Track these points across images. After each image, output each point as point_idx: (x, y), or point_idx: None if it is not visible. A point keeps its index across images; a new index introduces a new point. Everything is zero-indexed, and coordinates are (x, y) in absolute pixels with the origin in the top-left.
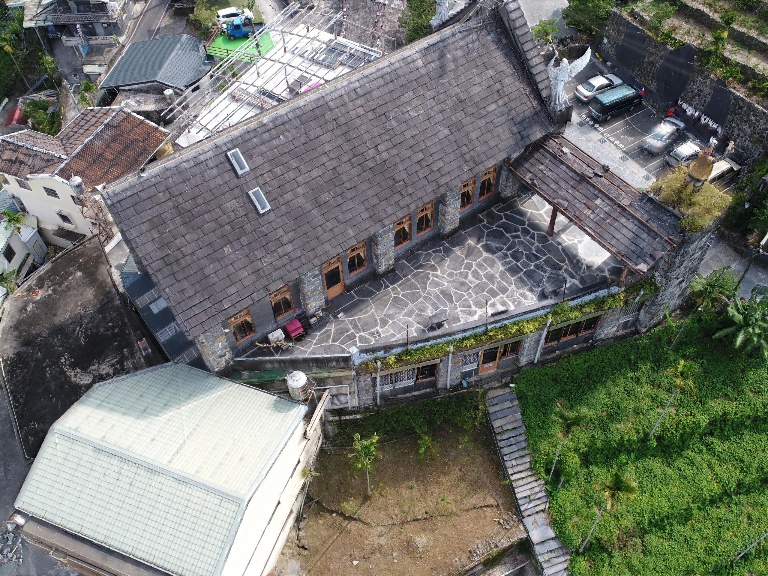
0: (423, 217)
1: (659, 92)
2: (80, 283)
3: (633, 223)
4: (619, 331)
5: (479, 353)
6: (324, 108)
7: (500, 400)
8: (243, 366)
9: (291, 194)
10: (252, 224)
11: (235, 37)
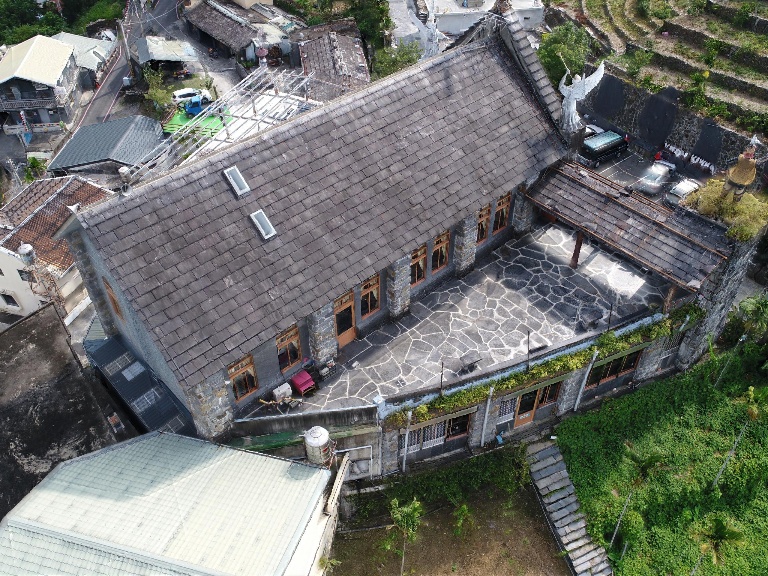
0: (438, 251)
1: (643, 138)
2: (33, 356)
3: (673, 239)
4: (658, 370)
5: (516, 400)
6: (329, 125)
7: (542, 456)
8: (245, 430)
9: (298, 218)
10: (256, 251)
11: (193, 115)
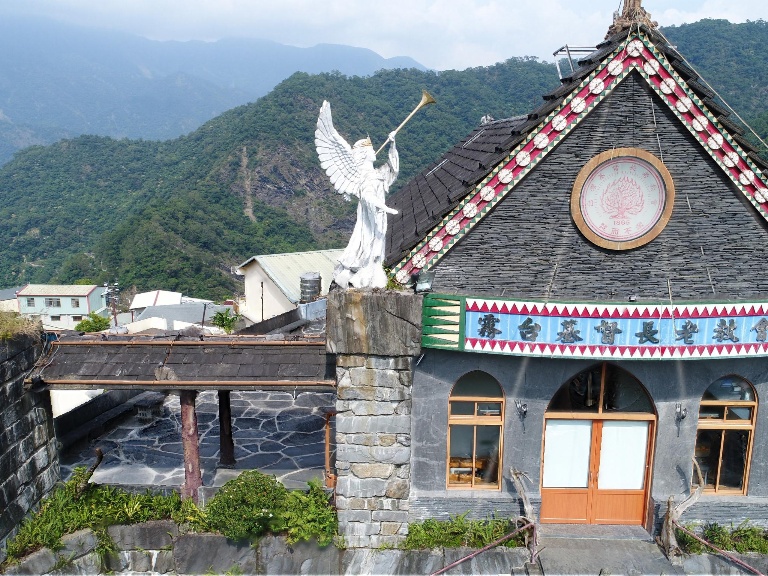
0: None
1: None
2: None
3: None
4: None
5: None
6: None
7: None
8: None
9: None
10: None
11: None
